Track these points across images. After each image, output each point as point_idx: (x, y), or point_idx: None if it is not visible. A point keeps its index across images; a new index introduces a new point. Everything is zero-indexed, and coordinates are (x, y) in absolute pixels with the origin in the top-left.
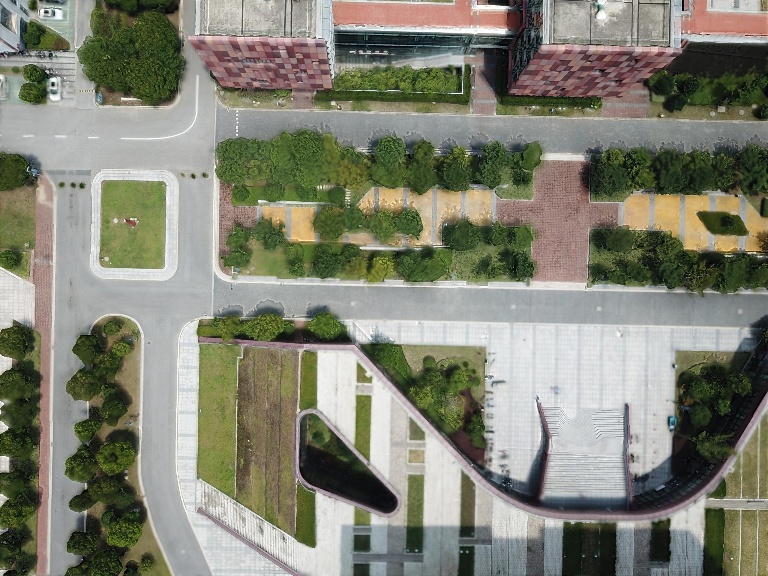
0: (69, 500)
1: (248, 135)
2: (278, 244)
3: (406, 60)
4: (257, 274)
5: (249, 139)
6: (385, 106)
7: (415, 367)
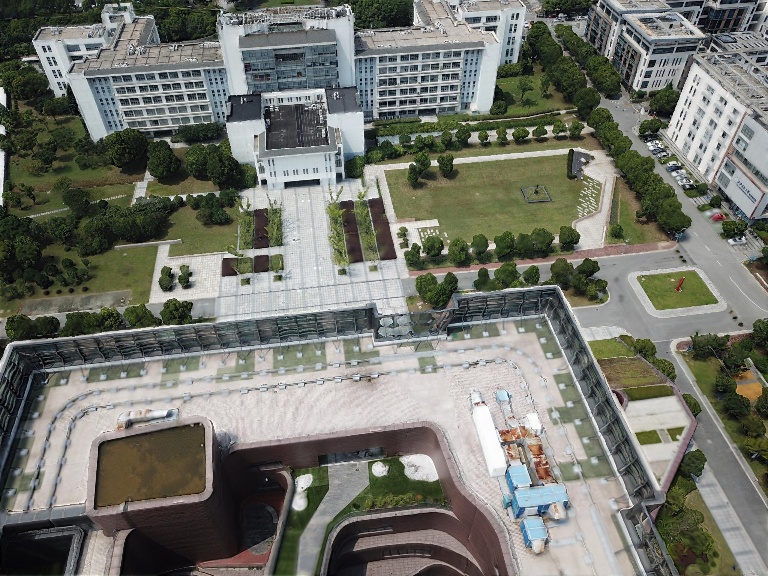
0: (466, 281)
1: None
2: (732, 368)
3: None
4: (690, 367)
5: None
6: None
7: None
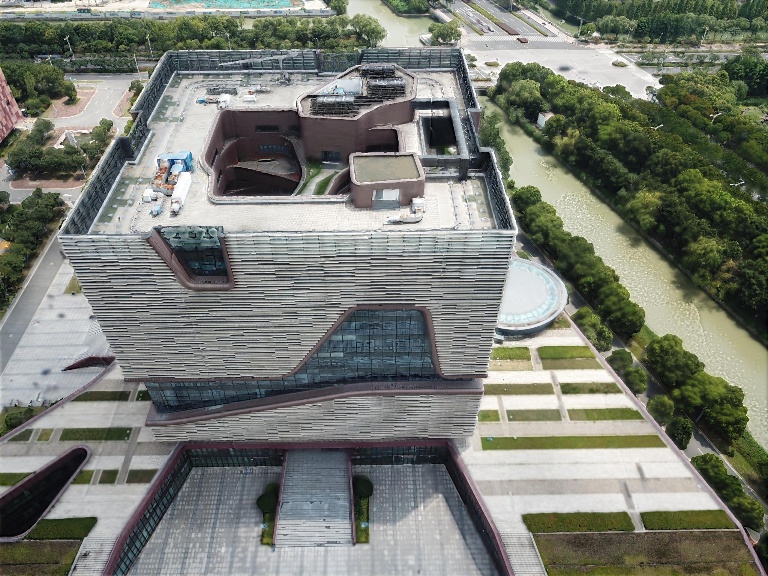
0: None
1: None
2: None
3: None
4: None
5: None
6: None
7: None
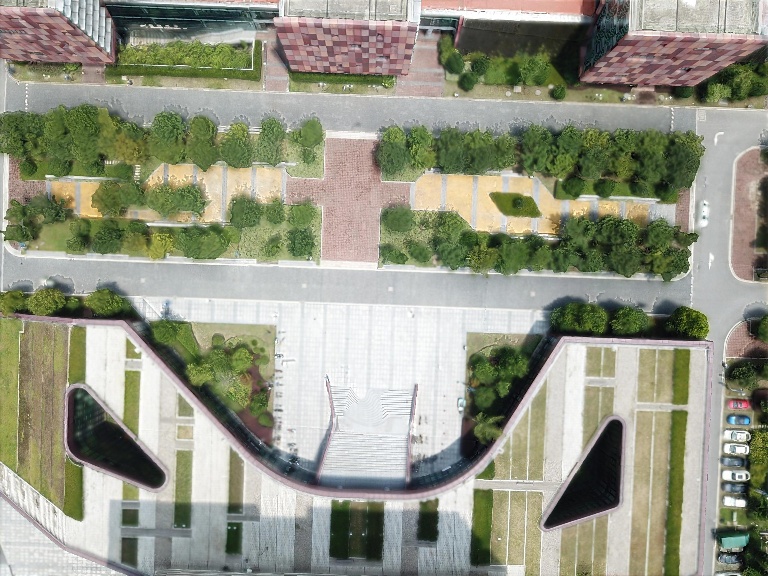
0: None
1: (38, 109)
2: (58, 219)
3: (203, 35)
4: (46, 249)
5: (26, 112)
6: (176, 81)
7: (204, 345)
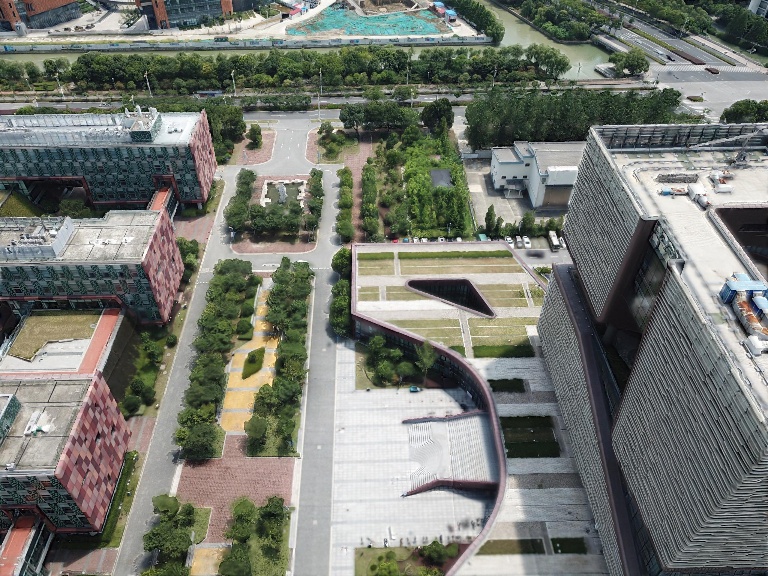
0: None
1: None
2: None
3: None
4: None
5: None
6: None
7: None
